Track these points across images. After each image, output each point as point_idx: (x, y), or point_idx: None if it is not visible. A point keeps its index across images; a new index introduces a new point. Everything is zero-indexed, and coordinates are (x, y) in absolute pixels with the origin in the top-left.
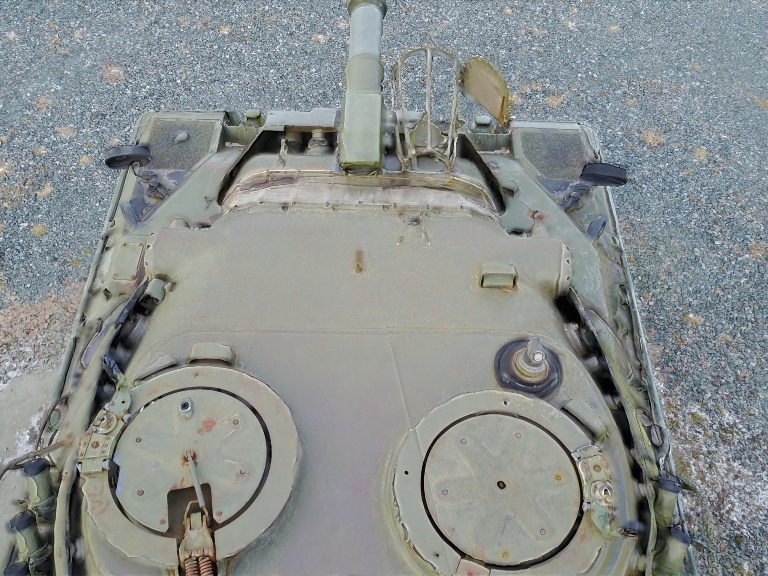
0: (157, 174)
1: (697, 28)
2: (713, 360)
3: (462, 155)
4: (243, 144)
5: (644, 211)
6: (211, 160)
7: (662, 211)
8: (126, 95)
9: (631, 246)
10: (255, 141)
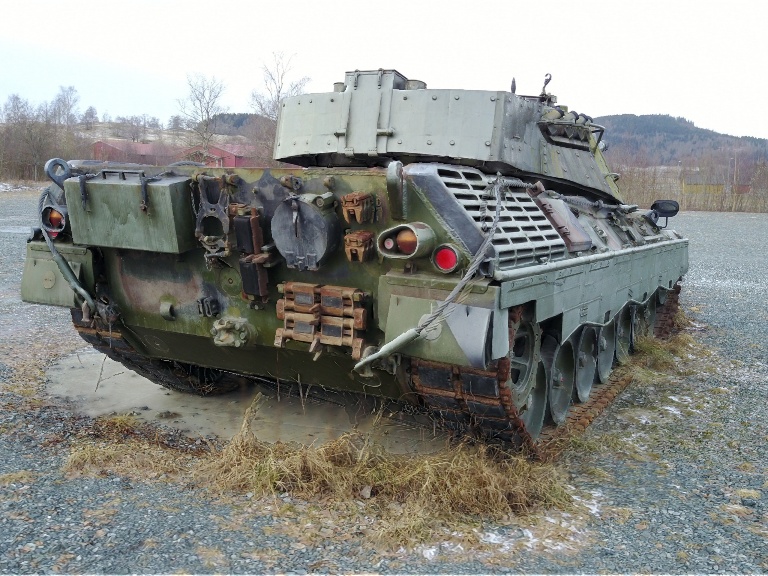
0: None
1: None
2: (762, 354)
3: None
4: None
5: None
6: None
7: (759, 329)
8: None
9: None
10: None
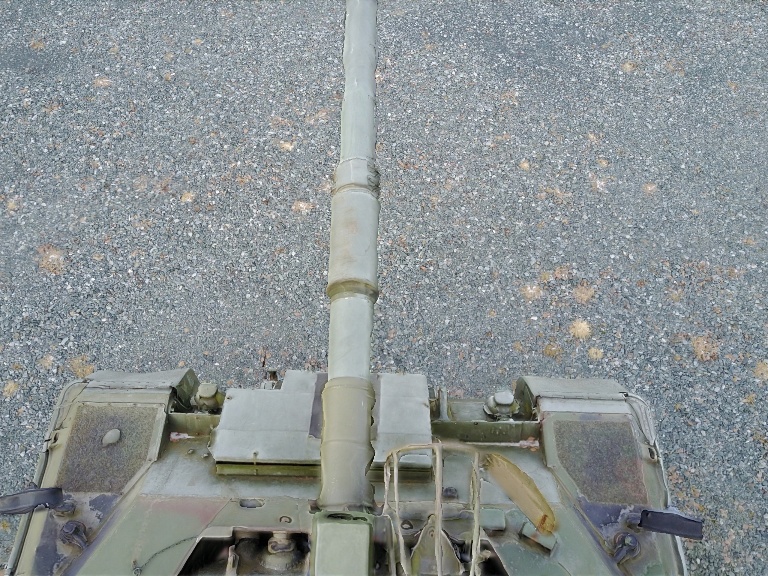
0: (76, 500)
1: (749, 187)
2: None
3: (485, 575)
4: (194, 435)
5: (699, 457)
6: (147, 483)
7: (721, 457)
8: (65, 291)
9: (685, 511)
10: (191, 556)
